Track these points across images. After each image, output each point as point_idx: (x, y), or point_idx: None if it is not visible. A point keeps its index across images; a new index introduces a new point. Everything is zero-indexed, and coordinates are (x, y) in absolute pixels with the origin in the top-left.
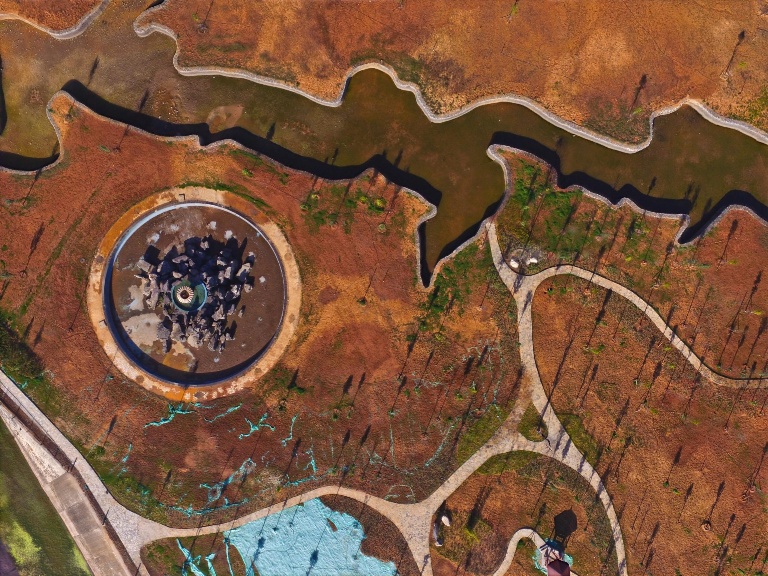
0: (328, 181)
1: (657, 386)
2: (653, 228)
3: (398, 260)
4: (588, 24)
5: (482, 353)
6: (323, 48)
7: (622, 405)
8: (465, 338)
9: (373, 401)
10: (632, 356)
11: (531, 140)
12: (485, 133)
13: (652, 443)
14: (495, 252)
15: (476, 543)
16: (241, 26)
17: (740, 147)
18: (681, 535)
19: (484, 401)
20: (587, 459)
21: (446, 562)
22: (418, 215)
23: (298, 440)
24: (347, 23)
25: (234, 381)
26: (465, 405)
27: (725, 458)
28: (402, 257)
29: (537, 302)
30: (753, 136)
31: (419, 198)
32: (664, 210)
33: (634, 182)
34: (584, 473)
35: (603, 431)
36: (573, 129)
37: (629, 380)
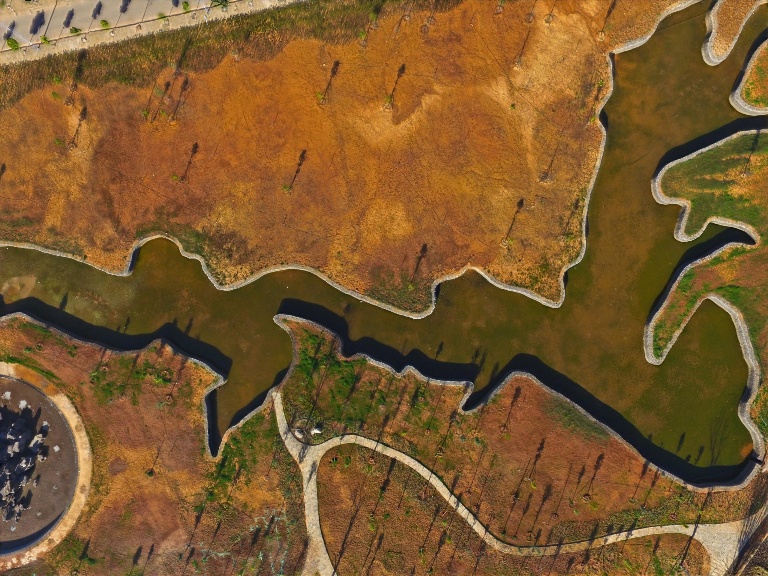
0: (116, 353)
1: (443, 554)
2: (437, 396)
3: (186, 431)
4: (368, 195)
5: (269, 523)
6: (109, 222)
7: (408, 574)
8: (252, 508)
9: (162, 572)
10: (417, 525)
11: (319, 306)
12: (274, 300)
13: None
14: (281, 422)
15: None
16: (28, 201)
17: (526, 310)
18: None
19: (271, 571)
20: None
21: None
22: (205, 385)
23: None
24: (131, 197)
25: (28, 552)
26: (253, 575)
27: None
28: (190, 428)
29: (322, 472)
30: (538, 300)
31: (206, 368)
32: (455, 372)
33: (421, 347)
34: None
35: None
36: (357, 297)
37: (415, 549)
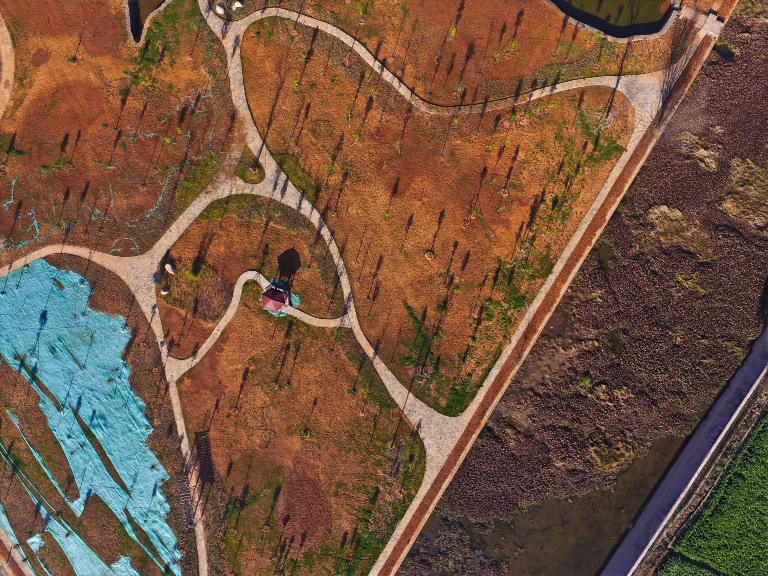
0: None
1: (370, 120)
2: None
3: (107, 17)
4: None
5: (195, 101)
6: None
7: (337, 141)
8: (178, 88)
9: (90, 157)
10: (343, 92)
11: None
12: None
13: (370, 177)
14: (202, 1)
15: (202, 289)
16: None
17: None
18: (405, 266)
19: (200, 148)
20: (306, 197)
21: (174, 311)
22: None
23: (19, 202)
24: None
25: None
26: (182, 154)
27: (444, 186)
28: (111, 14)
29: (246, 46)
30: None
31: None
32: None
33: None
34: (303, 211)
35: (320, 168)
36: None
37: (342, 116)
